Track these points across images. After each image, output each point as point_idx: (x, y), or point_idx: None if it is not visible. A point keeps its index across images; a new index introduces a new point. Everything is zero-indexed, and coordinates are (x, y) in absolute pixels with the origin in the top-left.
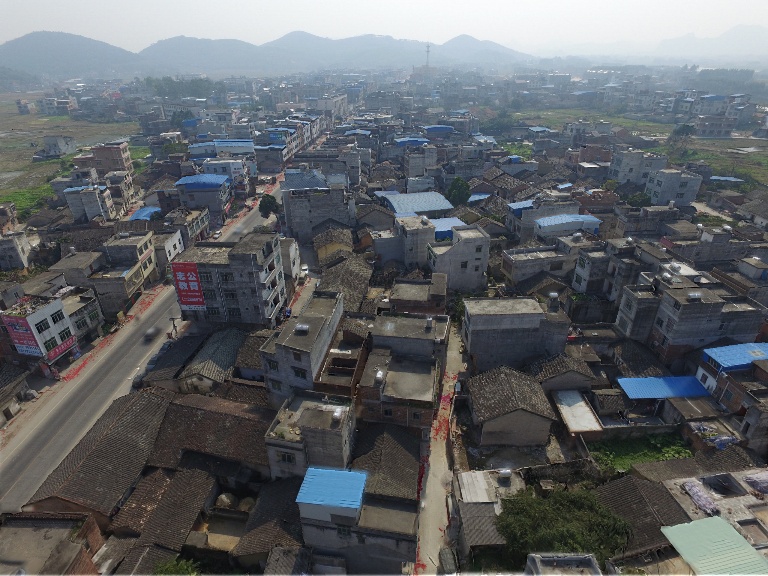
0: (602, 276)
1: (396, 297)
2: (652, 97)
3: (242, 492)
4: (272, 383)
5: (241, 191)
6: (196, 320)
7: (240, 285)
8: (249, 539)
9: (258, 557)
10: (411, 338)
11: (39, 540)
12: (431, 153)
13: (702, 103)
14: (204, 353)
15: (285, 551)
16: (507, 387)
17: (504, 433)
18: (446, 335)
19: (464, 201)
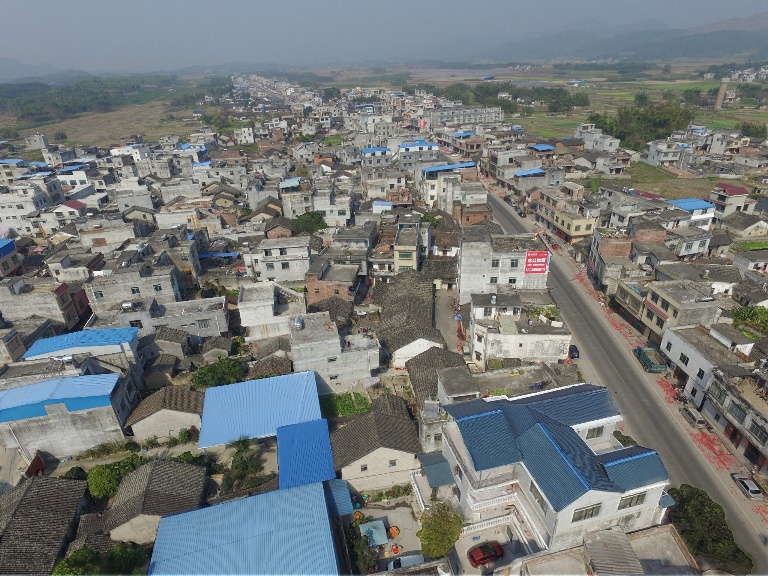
0: None
1: (354, 272)
2: None
3: None
4: None
5: None
6: None
7: None
8: None
9: None
10: (349, 230)
11: None
12: None
13: None
14: None
15: None
16: None
17: None
18: None
19: None
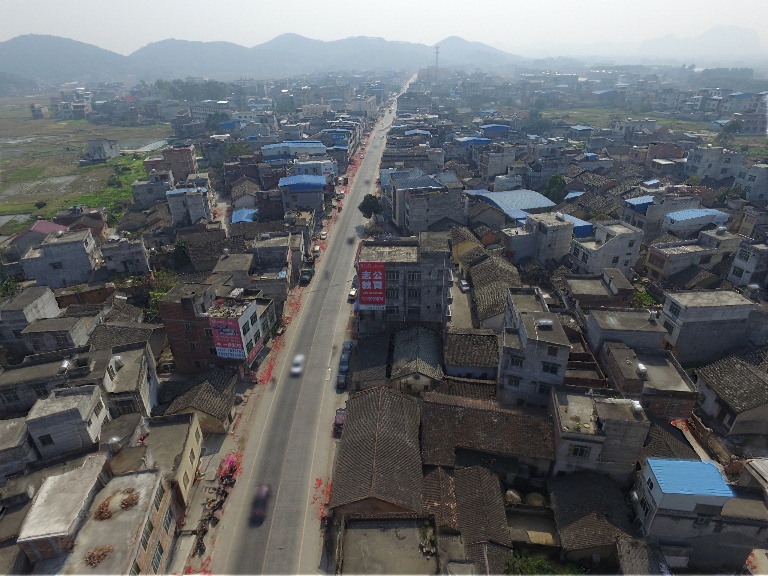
0: (766, 268)
1: (576, 292)
2: (676, 96)
3: (524, 488)
4: (509, 379)
5: (329, 192)
6: (372, 320)
7: (426, 283)
8: (574, 533)
9: (599, 550)
10: (643, 331)
11: (395, 540)
12: (509, 152)
13: (731, 101)
14: (404, 352)
15: (633, 543)
16: (752, 377)
17: (756, 422)
18: None
19: (561, 198)
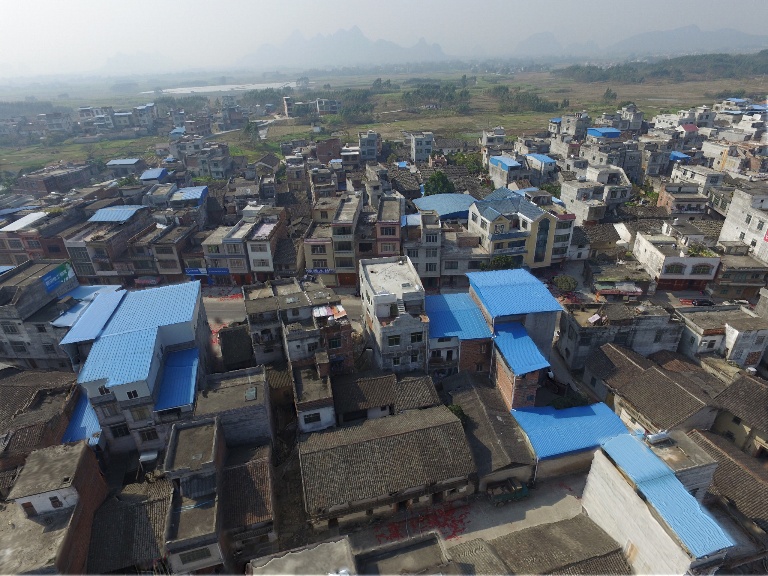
0: None
1: None
2: (65, 119)
3: None
4: None
5: None
6: None
7: None
8: None
9: None
10: None
11: None
12: None
13: (145, 114)
14: None
15: None
16: None
17: None
18: (729, 190)
19: None
